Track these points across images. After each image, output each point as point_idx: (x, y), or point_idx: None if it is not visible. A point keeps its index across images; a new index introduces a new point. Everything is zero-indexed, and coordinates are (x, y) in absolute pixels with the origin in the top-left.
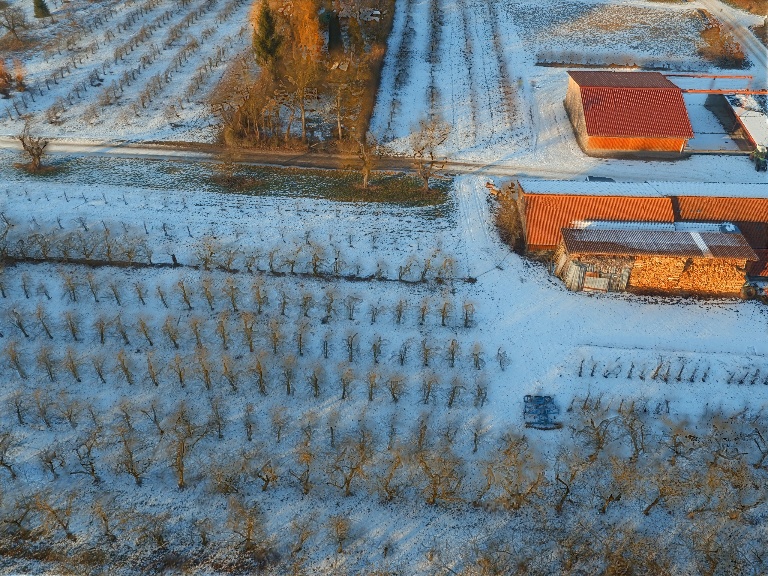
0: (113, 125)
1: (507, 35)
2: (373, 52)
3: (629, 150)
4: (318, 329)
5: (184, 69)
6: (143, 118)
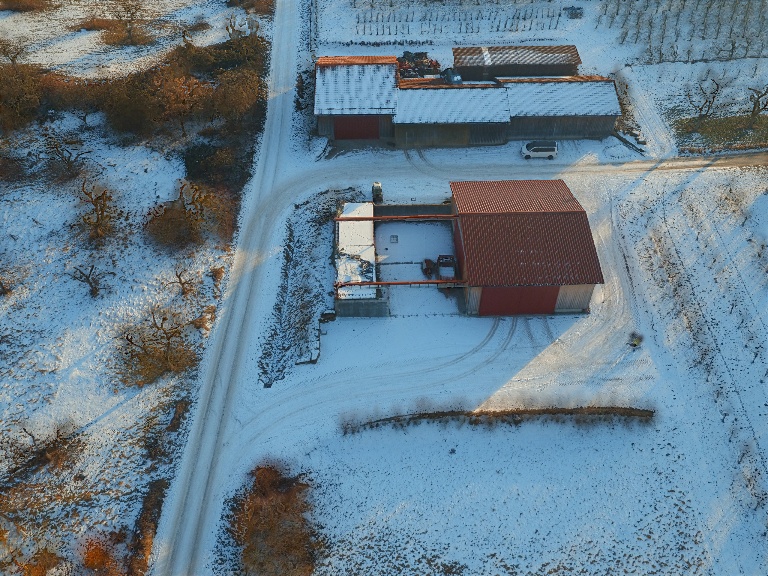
0: None
1: None
2: None
3: None
4: None
5: None
6: None
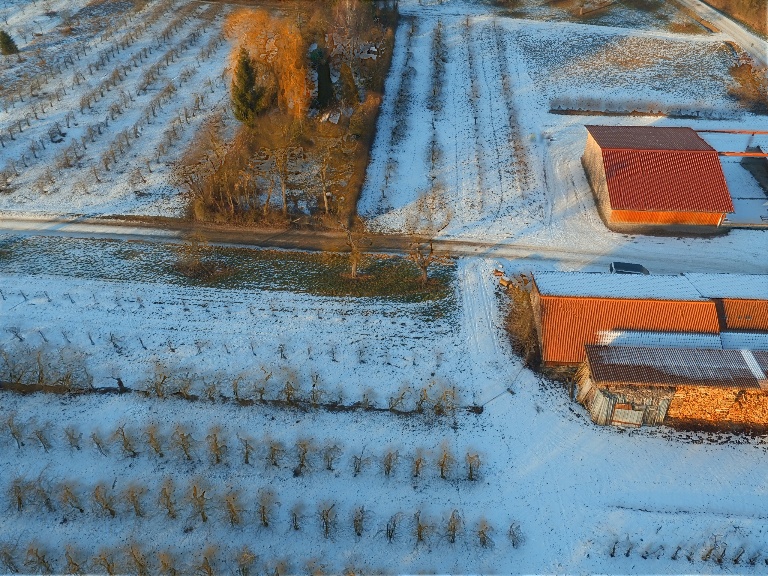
0: (70, 194)
1: (517, 74)
2: (367, 102)
3: (658, 223)
4: (288, 485)
5: (157, 120)
6: (105, 184)
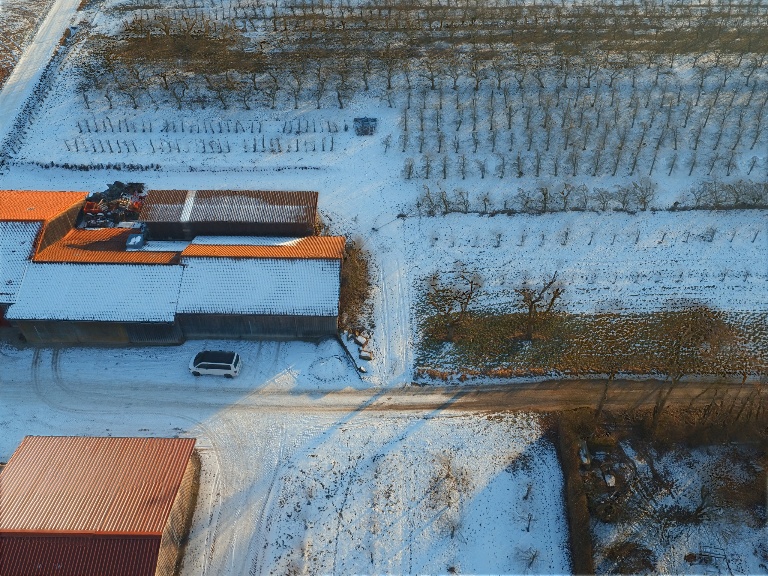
0: None
1: None
2: None
3: None
4: None
5: None
6: None
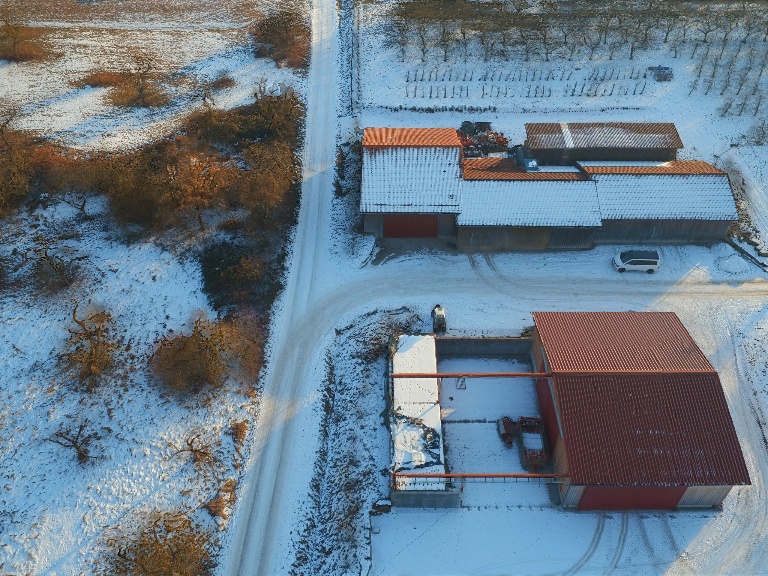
0: None
1: None
2: None
3: None
4: None
5: None
6: None
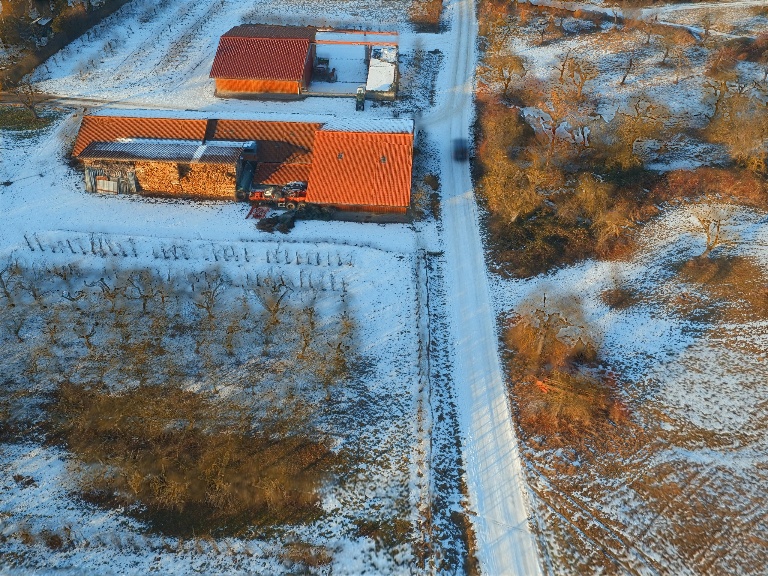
0: None
1: (244, 2)
2: (70, 9)
3: (254, 92)
4: None
5: None
6: None
